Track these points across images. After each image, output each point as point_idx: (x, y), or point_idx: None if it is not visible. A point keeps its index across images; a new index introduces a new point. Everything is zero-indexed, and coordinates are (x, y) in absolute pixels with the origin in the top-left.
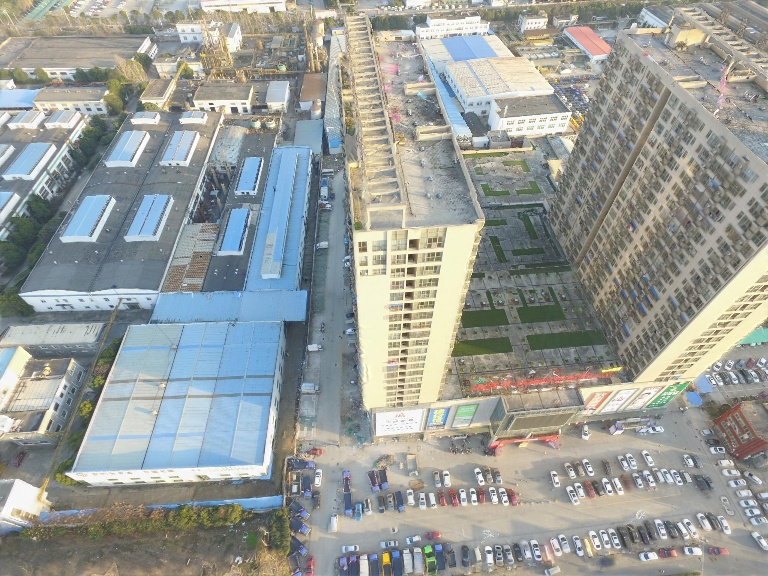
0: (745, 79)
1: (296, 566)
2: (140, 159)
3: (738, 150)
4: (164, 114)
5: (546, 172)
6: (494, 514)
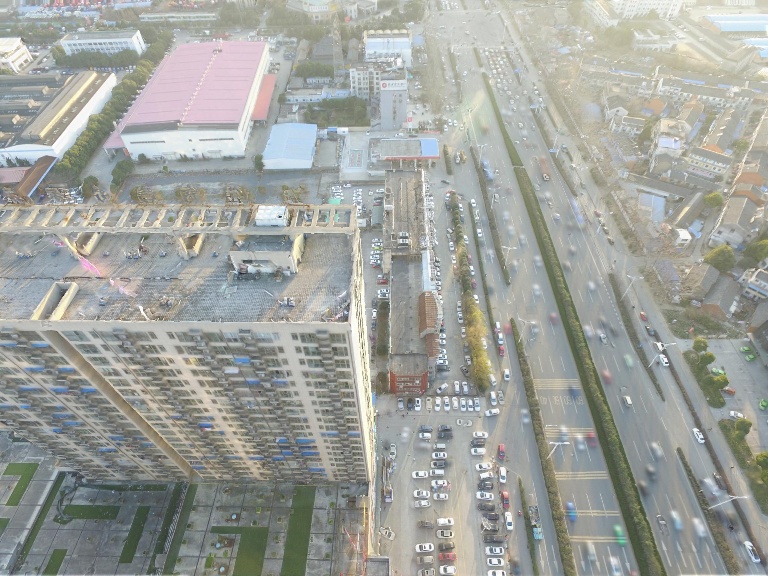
0: (98, 236)
1: None
2: None
3: (225, 329)
4: None
5: (4, 438)
6: None
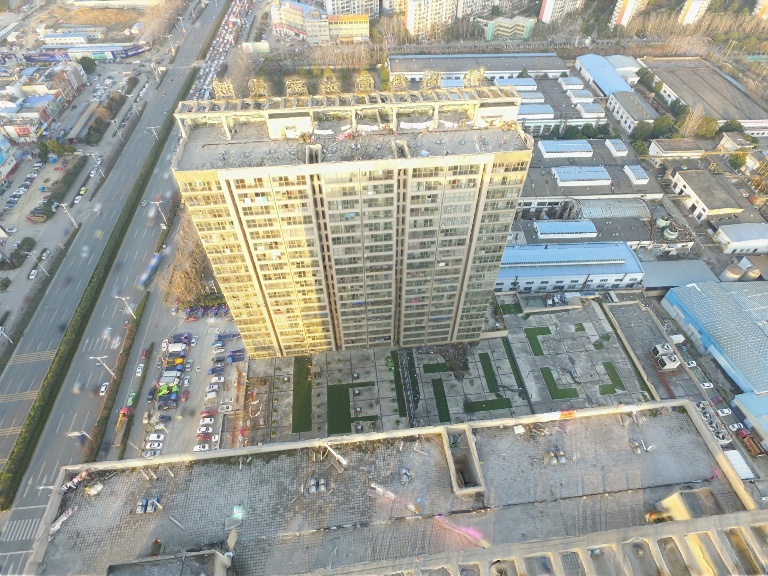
0: None
1: (193, 311)
2: (557, 158)
3: None
4: (634, 157)
5: None
6: (187, 447)
